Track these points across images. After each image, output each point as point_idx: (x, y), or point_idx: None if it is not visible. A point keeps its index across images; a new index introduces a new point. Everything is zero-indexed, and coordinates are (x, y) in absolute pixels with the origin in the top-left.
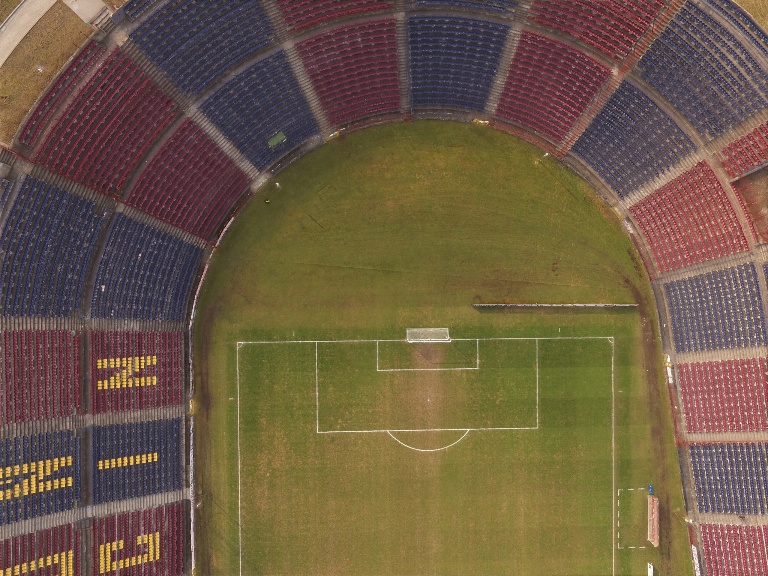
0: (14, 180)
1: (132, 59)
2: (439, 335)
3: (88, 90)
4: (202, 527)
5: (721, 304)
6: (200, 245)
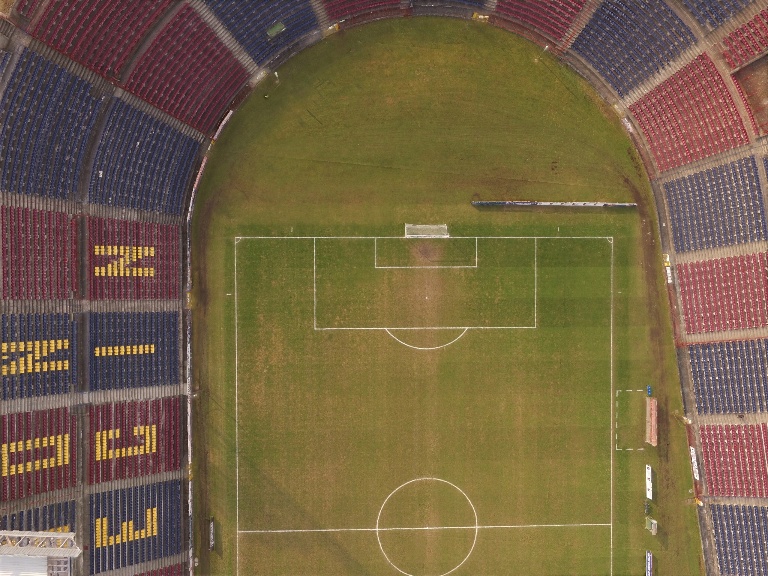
0: (12, 52)
1: None
2: (438, 233)
3: None
4: (199, 423)
5: (721, 200)
6: (198, 139)
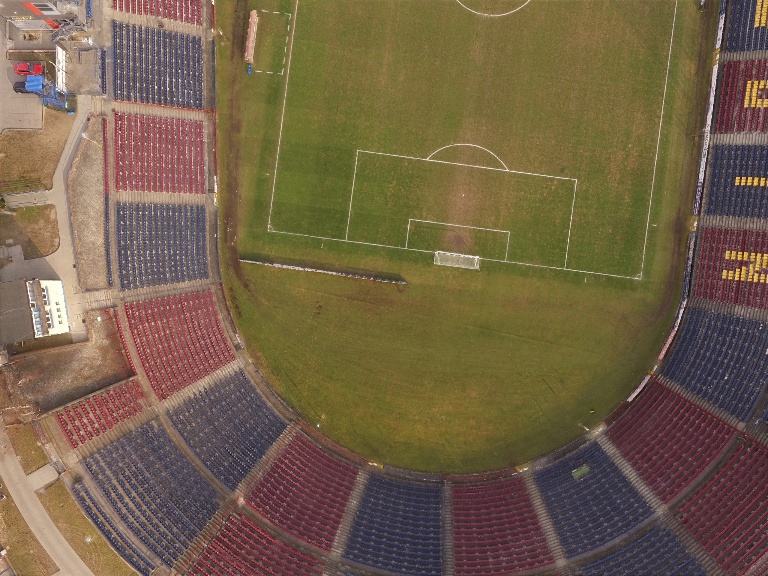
0: None
1: (720, 569)
2: (444, 258)
3: (767, 545)
4: (700, 104)
5: (157, 251)
6: (663, 378)
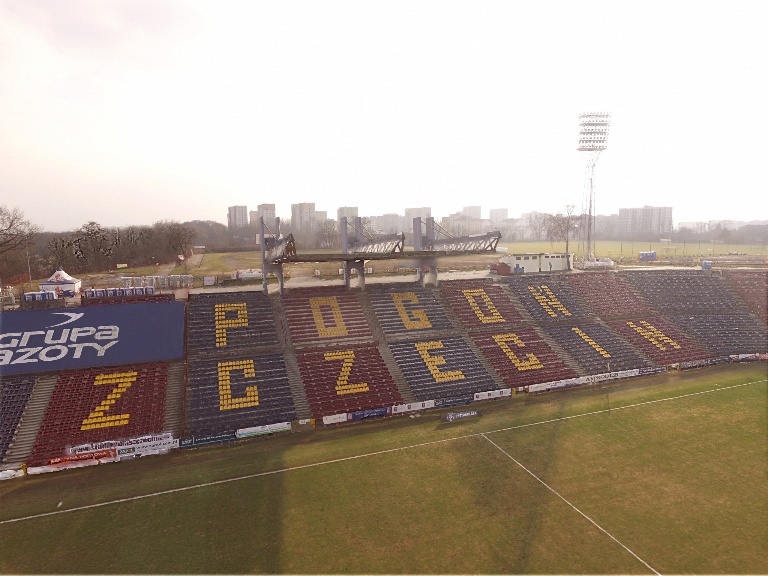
0: None
1: None
2: None
3: None
4: (572, 393)
5: None
6: None
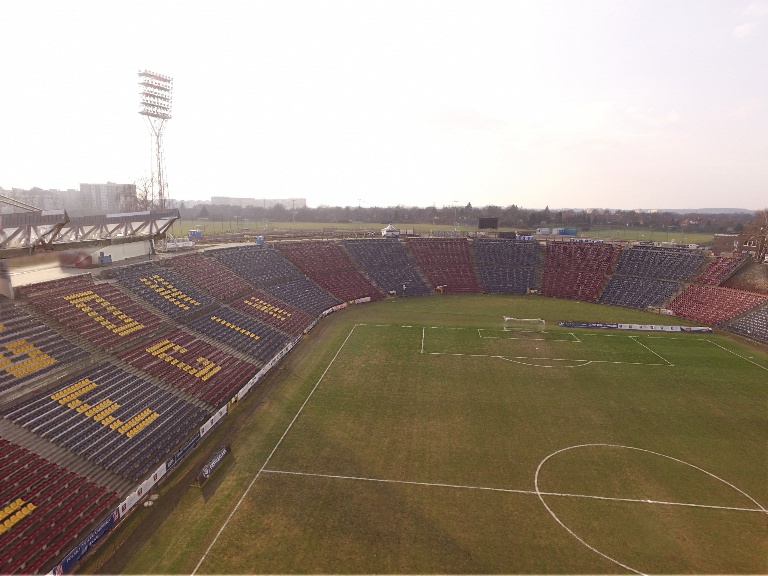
0: None
1: None
2: None
3: (318, 248)
4: (268, 385)
5: None
6: None
